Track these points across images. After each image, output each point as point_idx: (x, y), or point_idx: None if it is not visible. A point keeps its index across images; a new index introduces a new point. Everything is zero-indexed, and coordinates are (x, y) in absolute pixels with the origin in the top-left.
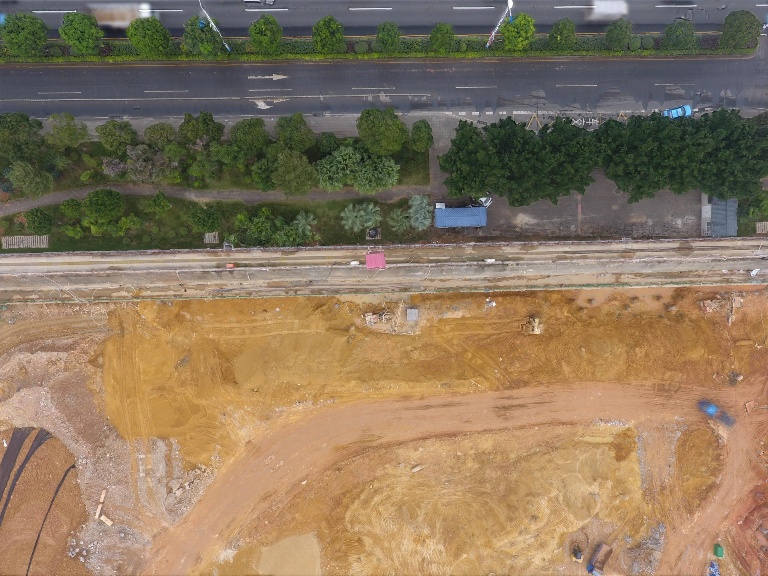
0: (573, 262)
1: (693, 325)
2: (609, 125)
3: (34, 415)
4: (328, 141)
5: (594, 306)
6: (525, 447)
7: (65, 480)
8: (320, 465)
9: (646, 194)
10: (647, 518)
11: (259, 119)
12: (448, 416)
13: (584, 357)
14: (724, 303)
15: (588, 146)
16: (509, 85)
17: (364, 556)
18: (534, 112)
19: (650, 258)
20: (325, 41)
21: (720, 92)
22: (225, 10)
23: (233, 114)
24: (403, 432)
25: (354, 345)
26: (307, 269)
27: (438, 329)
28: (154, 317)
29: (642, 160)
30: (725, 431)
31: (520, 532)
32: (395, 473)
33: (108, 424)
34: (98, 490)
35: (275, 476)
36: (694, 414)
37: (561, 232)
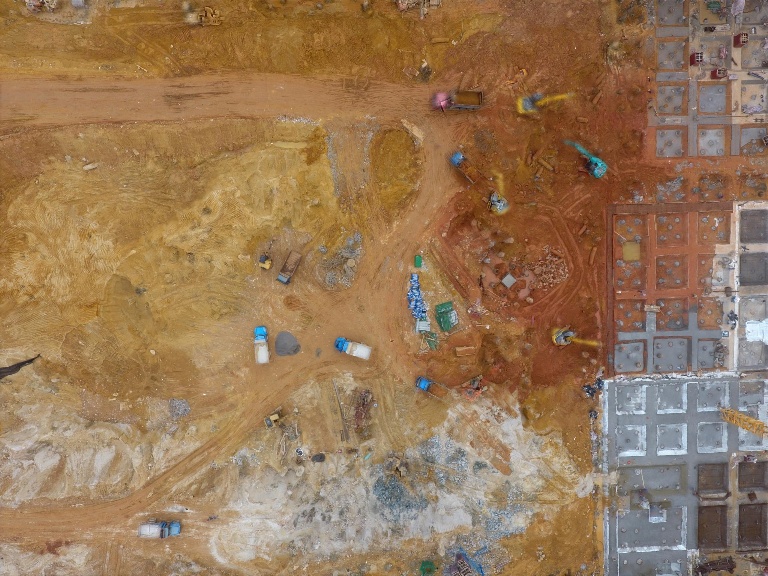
0: None
1: (384, 19)
2: None
3: None
4: None
5: (287, 7)
6: (209, 149)
7: None
8: None
9: None
10: (345, 229)
11: None
12: (112, 102)
13: (257, 41)
14: None
15: None
16: None
17: (27, 253)
18: None
19: None
20: None
21: None
22: None
23: None
24: (60, 115)
25: (12, 27)
26: None
27: (109, 18)
28: None
29: None
30: (420, 132)
31: (192, 227)
32: (63, 168)
33: None
34: None
35: None
36: (386, 113)
37: None
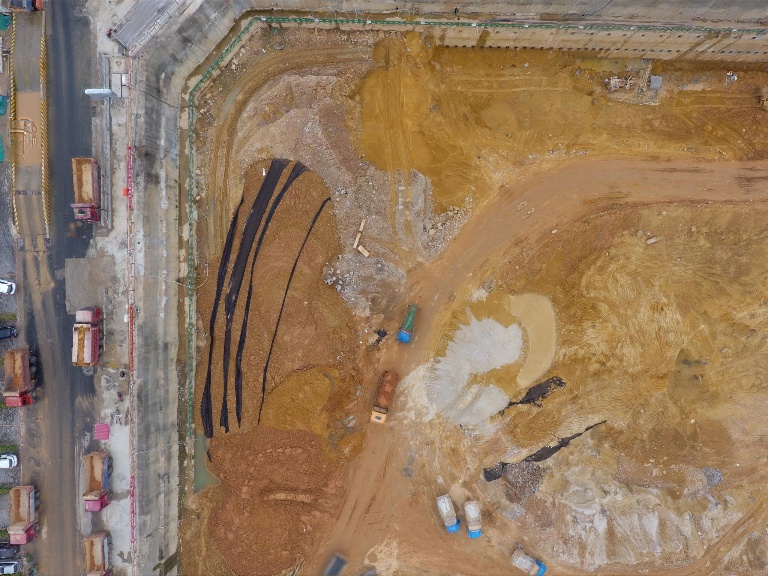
0: None
1: None
2: None
3: (294, 145)
4: None
5: None
6: (759, 228)
7: (322, 211)
8: (570, 216)
9: None
10: None
11: None
12: (692, 182)
13: None
14: None
15: None
16: None
17: (599, 322)
18: None
19: None
20: None
21: None
22: None
23: None
24: (649, 193)
25: (599, 107)
26: None
27: (678, 100)
28: (419, 52)
29: None
30: None
31: (760, 305)
32: (631, 242)
33: (363, 161)
34: (356, 221)
35: (526, 223)
36: None
37: None
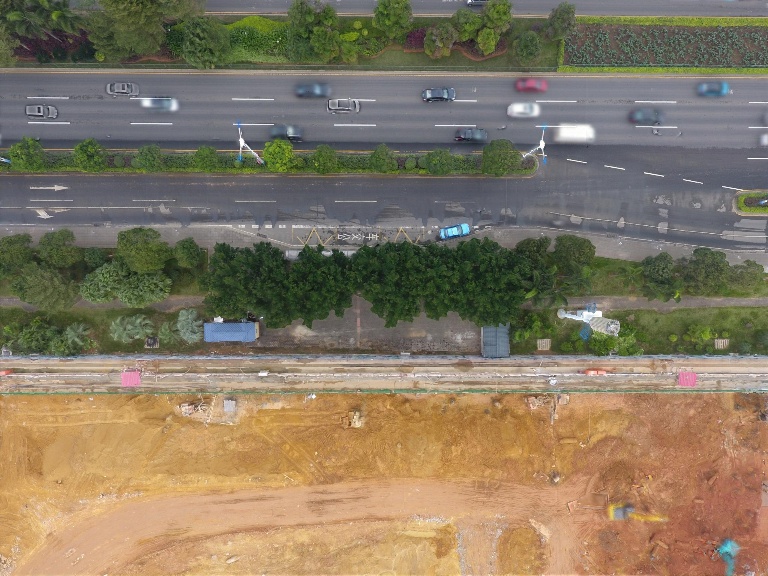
0: (351, 375)
1: (516, 422)
2: (360, 253)
3: None
4: (92, 258)
5: (421, 398)
6: (344, 540)
7: None
8: (122, 559)
9: (402, 319)
10: None
11: (21, 237)
12: (259, 510)
13: (399, 454)
14: (549, 400)
15: (334, 275)
16: (289, 200)
17: None
18: (314, 226)
19: (425, 374)
20: (84, 164)
21: (500, 210)
22: (9, 123)
23: (15, 223)
24: (211, 526)
25: (168, 436)
26: (85, 376)
27: (257, 420)
28: None
29: (389, 290)
30: (547, 530)
31: None
32: (208, 564)
33: None
34: None
35: (76, 569)
36: (515, 512)
37: (340, 345)
